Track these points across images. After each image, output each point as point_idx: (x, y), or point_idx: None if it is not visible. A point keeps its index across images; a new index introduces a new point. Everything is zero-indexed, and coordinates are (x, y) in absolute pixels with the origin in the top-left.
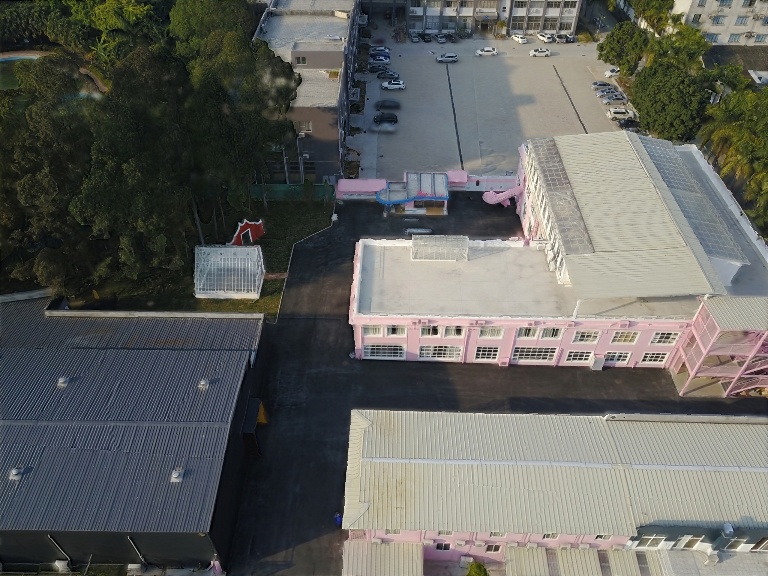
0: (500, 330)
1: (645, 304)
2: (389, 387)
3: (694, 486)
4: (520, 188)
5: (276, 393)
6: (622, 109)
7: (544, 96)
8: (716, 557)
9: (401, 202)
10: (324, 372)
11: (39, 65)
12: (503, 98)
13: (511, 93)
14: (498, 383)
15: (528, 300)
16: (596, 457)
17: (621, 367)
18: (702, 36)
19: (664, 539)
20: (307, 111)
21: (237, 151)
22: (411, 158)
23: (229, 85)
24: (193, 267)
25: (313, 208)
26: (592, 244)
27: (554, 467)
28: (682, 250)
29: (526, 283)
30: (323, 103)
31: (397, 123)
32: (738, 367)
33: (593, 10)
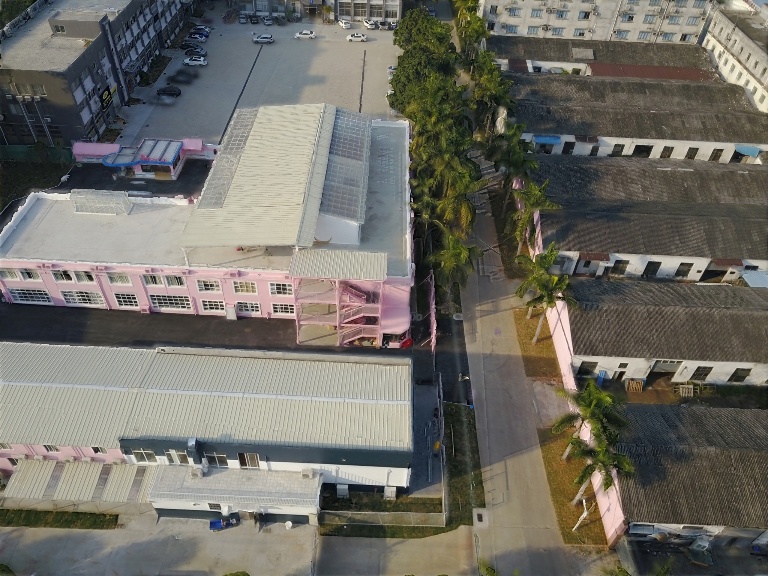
0: (127, 277)
1: (268, 257)
2: (24, 328)
3: (193, 408)
4: None
5: None
6: None
7: (338, 77)
8: (199, 470)
9: (130, 166)
10: None
11: None
12: (298, 78)
13: (308, 73)
14: (132, 328)
15: (161, 251)
16: (120, 382)
17: (257, 317)
18: (482, 25)
19: (154, 454)
20: (36, 75)
21: None
22: (175, 128)
23: None
24: None
25: (50, 169)
26: (224, 200)
27: (74, 389)
28: (296, 207)
29: (169, 236)
30: (61, 69)
31: (180, 96)
32: (336, 316)
33: (426, 0)
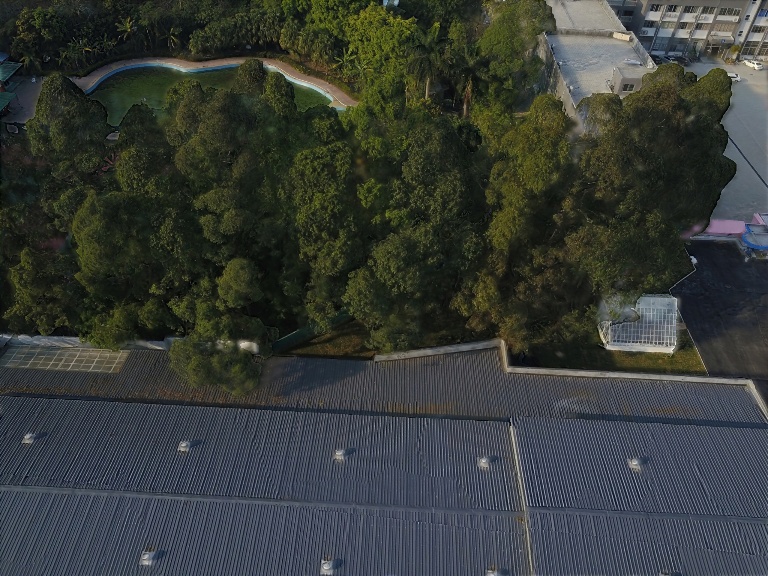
0: None
1: None
2: None
3: None
4: None
5: None
6: None
7: None
8: None
9: None
10: None
11: (604, 106)
12: None
13: None
14: None
15: None
16: None
17: None
18: None
19: None
20: None
21: None
22: (725, 194)
23: None
24: None
25: None
26: None
27: None
28: None
29: None
30: None
31: None
32: None
33: None
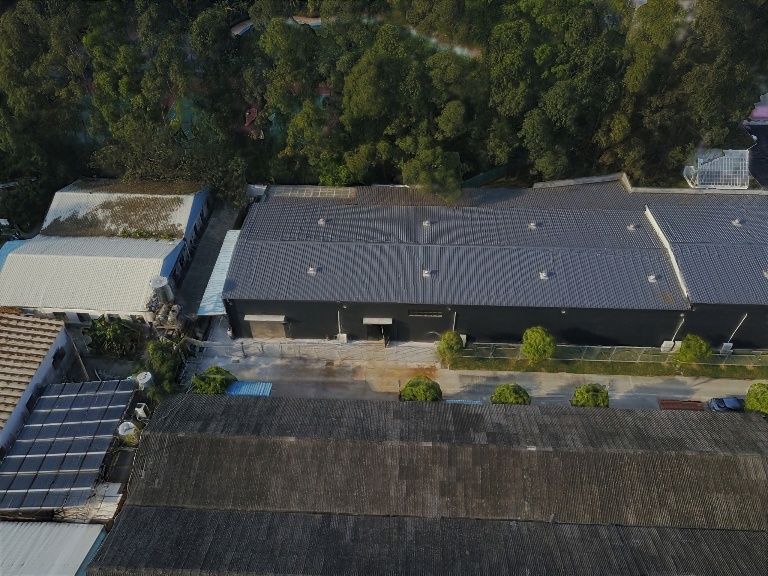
0: None
1: None
2: None
3: None
4: None
5: None
6: None
7: None
8: None
9: None
10: None
11: None
12: None
13: None
14: None
15: None
16: None
17: None
18: None
19: None
20: None
21: None
22: None
23: None
24: (697, 165)
25: None
26: None
27: None
28: None
29: None
30: None
31: None
32: None
33: None
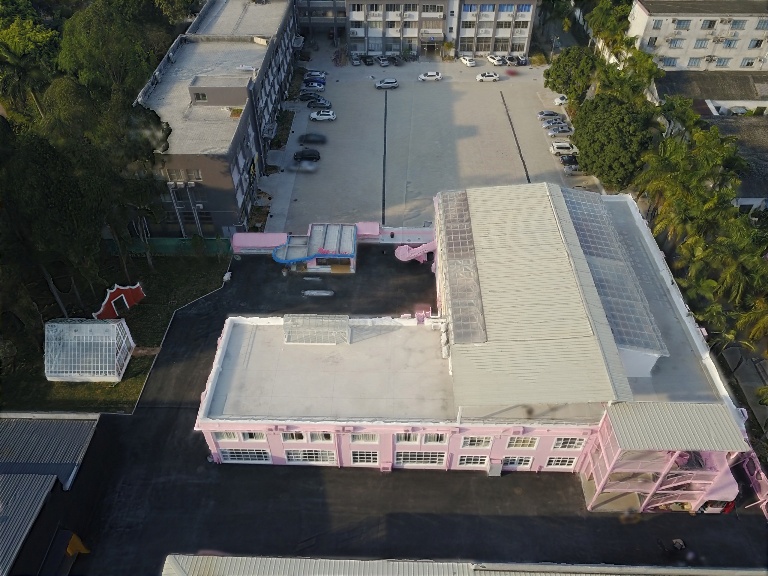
0: (375, 435)
1: None
2: (246, 501)
3: None
4: (434, 244)
5: (111, 510)
6: (566, 144)
7: (485, 127)
8: None
9: None
10: (173, 481)
11: None
12: (440, 130)
13: (450, 124)
14: (376, 494)
15: (410, 397)
16: None
17: (524, 471)
18: (654, 63)
19: None
20: (194, 159)
21: (75, 220)
22: (328, 202)
23: (66, 143)
24: (43, 346)
25: (206, 265)
26: (486, 330)
27: None
28: (588, 341)
29: (412, 374)
30: (216, 148)
31: (319, 160)
32: (652, 482)
33: (549, 29)
